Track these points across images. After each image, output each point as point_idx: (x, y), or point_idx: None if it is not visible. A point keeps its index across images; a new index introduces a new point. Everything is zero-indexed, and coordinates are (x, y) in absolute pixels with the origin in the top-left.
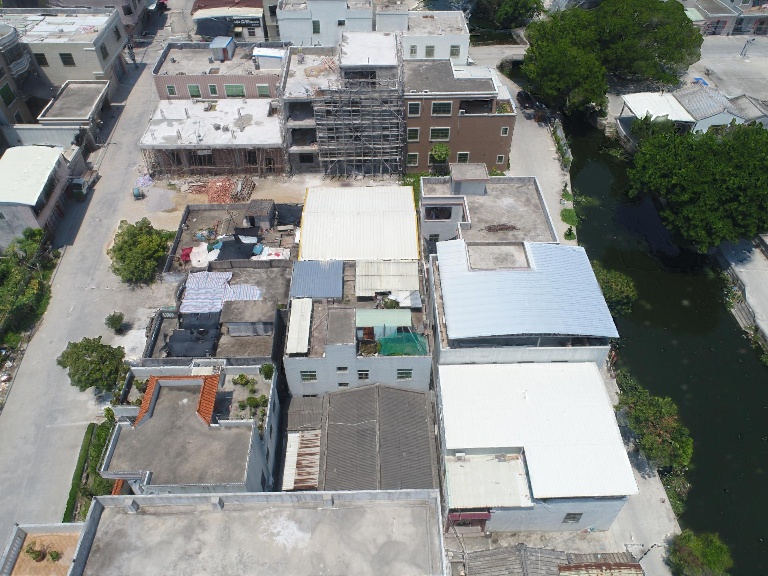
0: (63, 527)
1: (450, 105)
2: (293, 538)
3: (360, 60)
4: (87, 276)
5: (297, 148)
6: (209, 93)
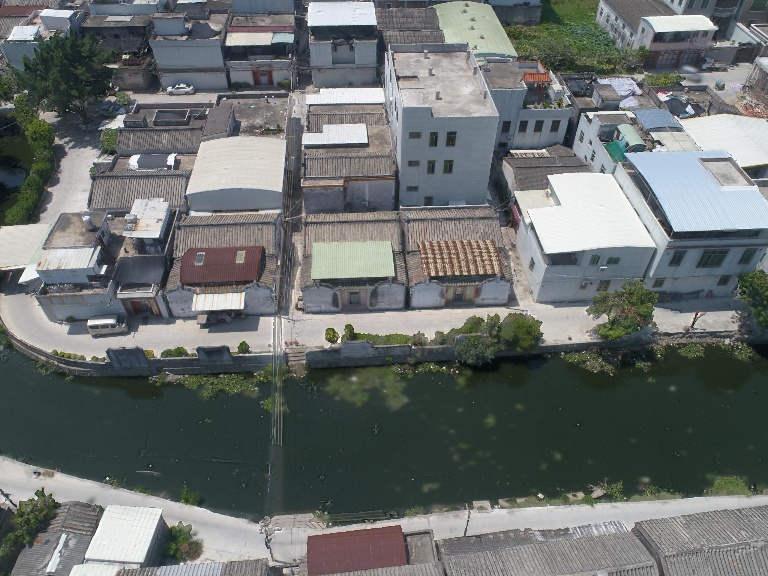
0: None
1: None
2: (466, 90)
3: None
4: None
5: None
6: None
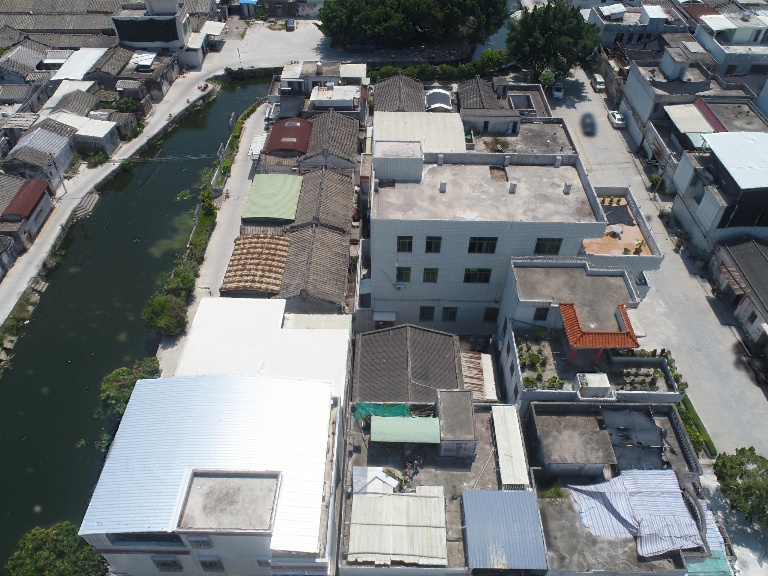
0: (632, 258)
1: None
2: (467, 214)
3: None
4: None
5: None
6: None
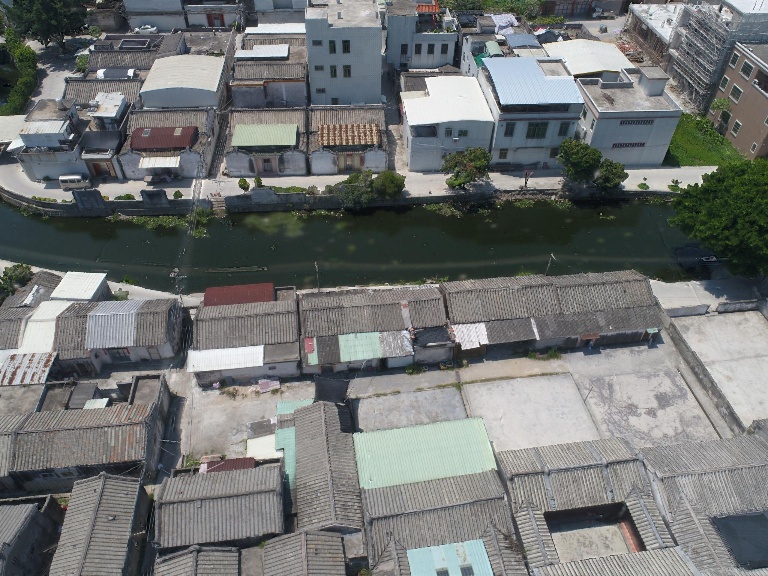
0: None
1: (752, 70)
2: (363, 13)
3: (738, 3)
4: None
5: (673, 51)
6: None
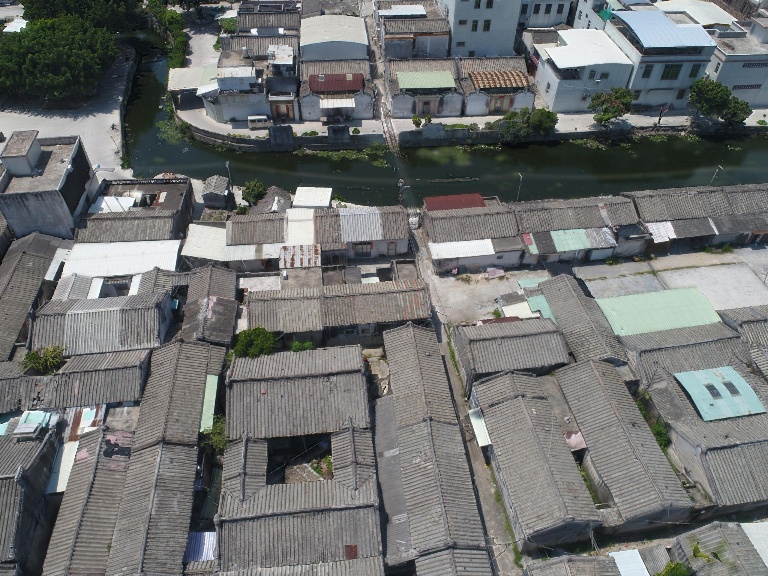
0: None
1: None
2: None
3: None
4: None
5: (763, 11)
6: None
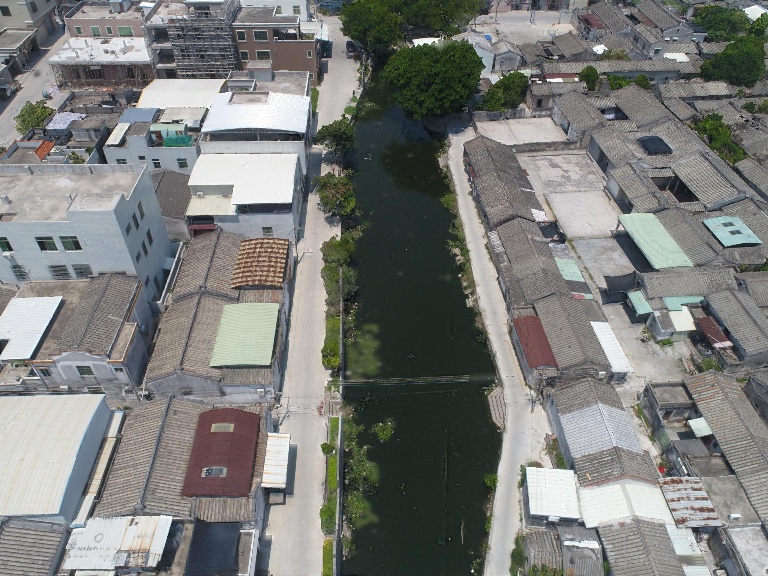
0: None
1: (266, 33)
2: (65, 183)
3: None
4: (1, 138)
5: (162, 65)
6: (107, 33)
